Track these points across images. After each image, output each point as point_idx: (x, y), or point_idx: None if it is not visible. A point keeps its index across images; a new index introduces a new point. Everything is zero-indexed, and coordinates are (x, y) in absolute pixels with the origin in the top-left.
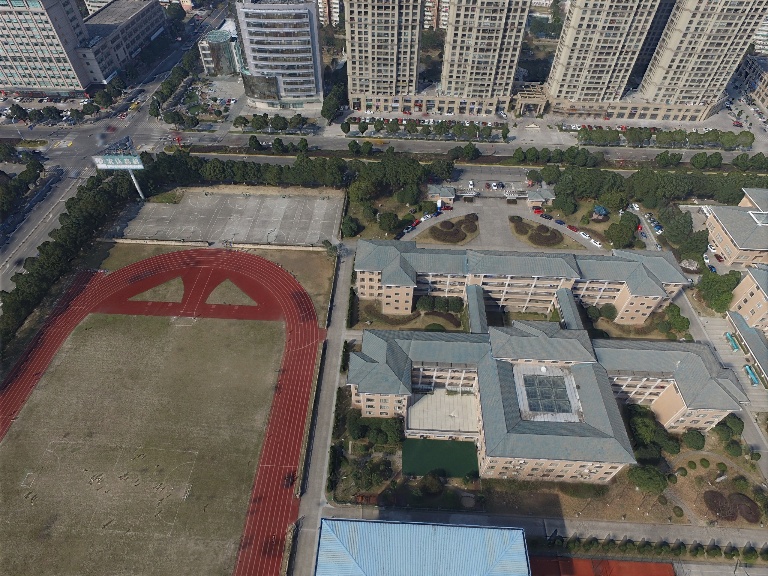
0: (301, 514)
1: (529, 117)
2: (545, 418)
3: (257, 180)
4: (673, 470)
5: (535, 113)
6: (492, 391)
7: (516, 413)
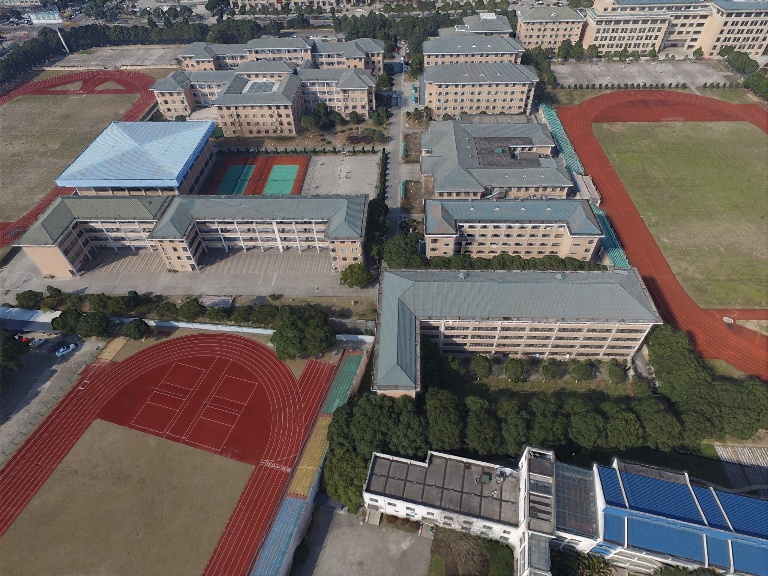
0: None
1: (361, 6)
2: None
3: (146, 38)
4: None
5: (366, 4)
6: (227, 85)
7: (237, 92)
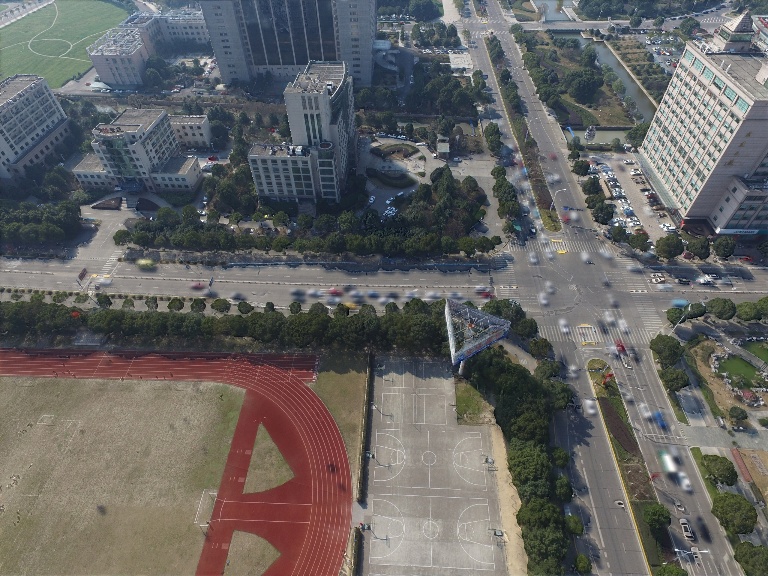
0: None
1: None
2: None
3: None
4: None
5: None
6: None
7: None
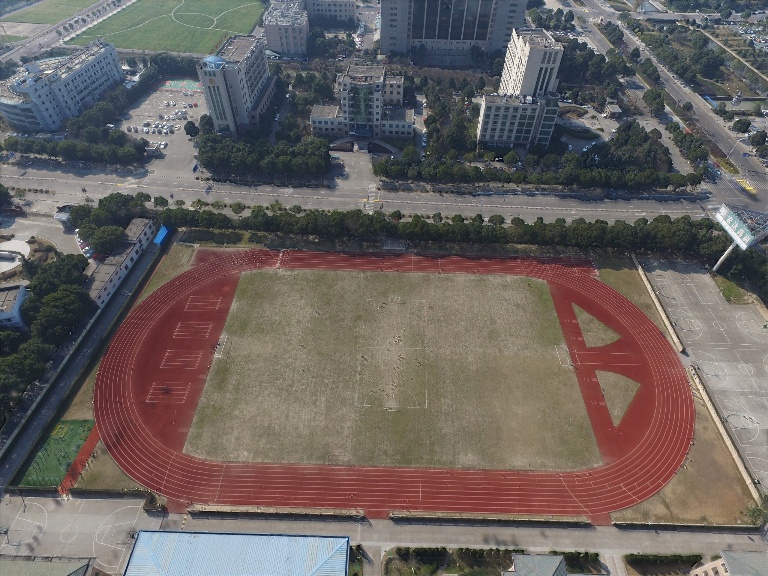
0: (374, 522)
1: None
2: None
3: None
4: None
5: None
6: None
7: None
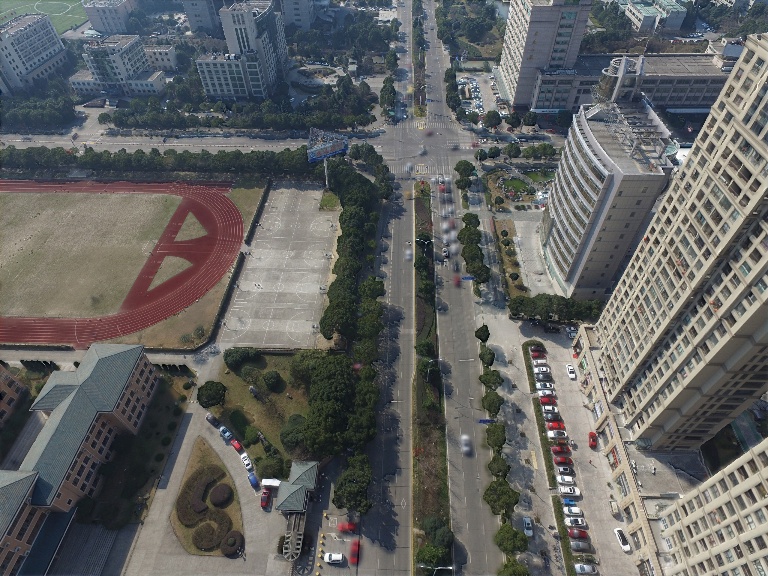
0: None
1: None
2: None
3: None
4: None
5: None
6: None
7: None
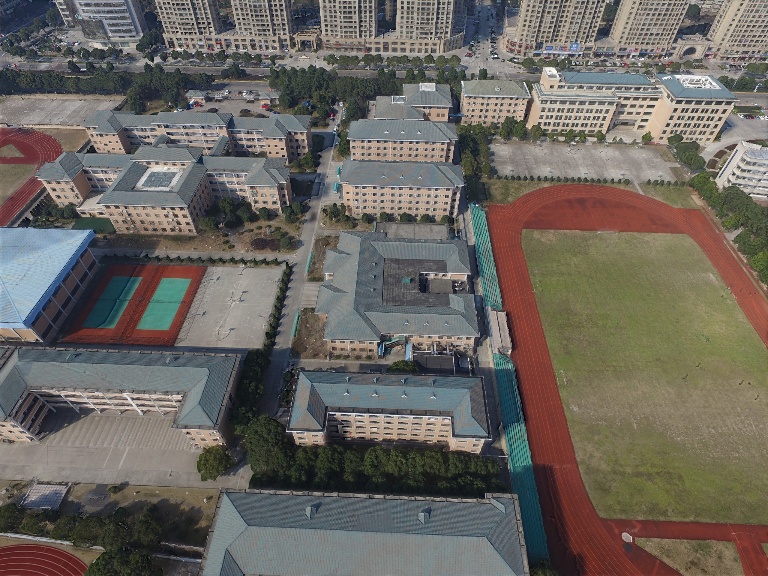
0: None
1: (306, 52)
2: (148, 189)
3: (61, 88)
4: (245, 230)
5: None
6: None
7: (130, 186)
